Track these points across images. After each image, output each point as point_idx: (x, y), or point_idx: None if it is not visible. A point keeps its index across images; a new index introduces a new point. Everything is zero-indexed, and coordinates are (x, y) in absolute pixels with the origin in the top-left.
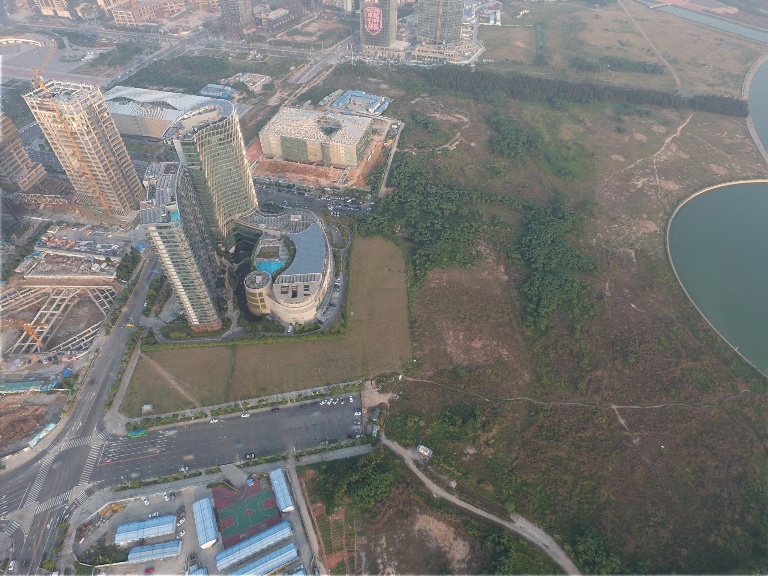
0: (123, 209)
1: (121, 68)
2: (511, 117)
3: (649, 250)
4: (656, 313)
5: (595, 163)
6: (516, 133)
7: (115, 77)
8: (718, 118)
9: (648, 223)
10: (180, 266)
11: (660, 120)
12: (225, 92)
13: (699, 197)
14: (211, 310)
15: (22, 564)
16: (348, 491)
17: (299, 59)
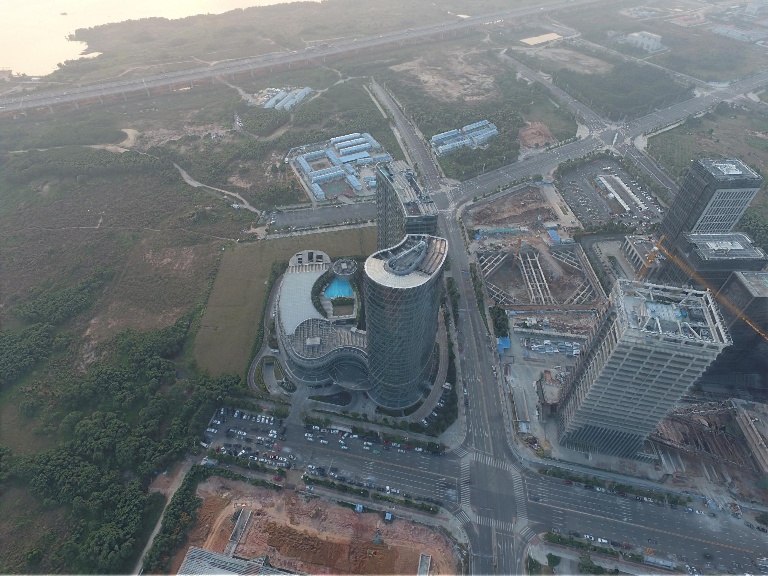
0: None
1: None
2: None
3: None
4: None
5: None
6: None
7: None
8: None
9: None
10: None
11: None
12: None
13: None
14: None
15: None
16: None
17: None
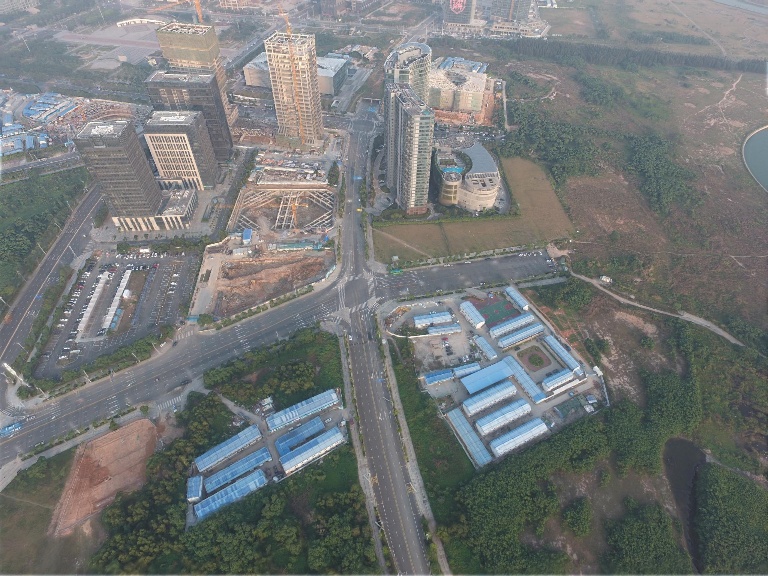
0: (314, 138)
1: (245, 42)
2: (592, 76)
3: (732, 165)
4: (748, 204)
5: (672, 108)
6: (602, 87)
7: (244, 49)
8: (764, 77)
9: (726, 148)
10: (422, 153)
11: (717, 78)
12: None
13: (761, 132)
14: (426, 194)
15: (357, 337)
16: (563, 299)
17: (394, 34)
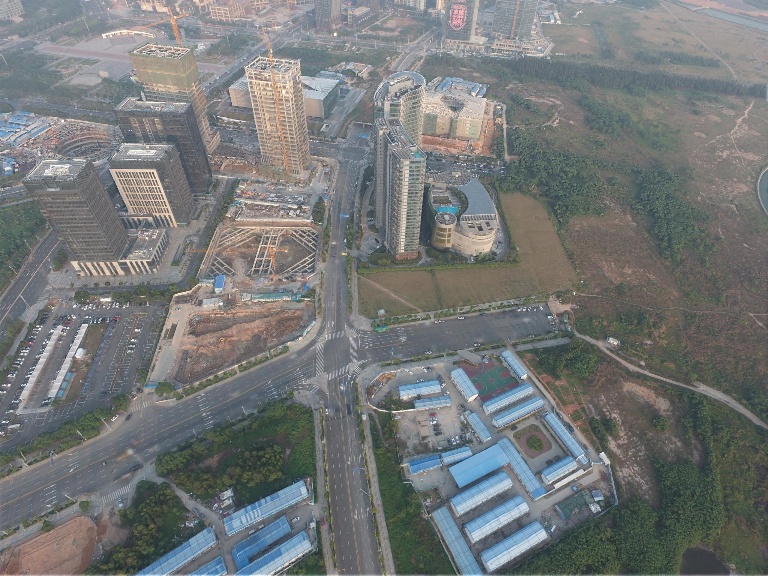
0: (299, 168)
1: None
2: (597, 101)
3: (747, 205)
4: (766, 250)
5: (682, 138)
6: (608, 113)
7: (233, 65)
8: None
9: (740, 185)
10: (412, 197)
11: (728, 105)
12: (337, 78)
13: None
14: (417, 239)
15: (334, 411)
16: (565, 366)
17: (390, 51)
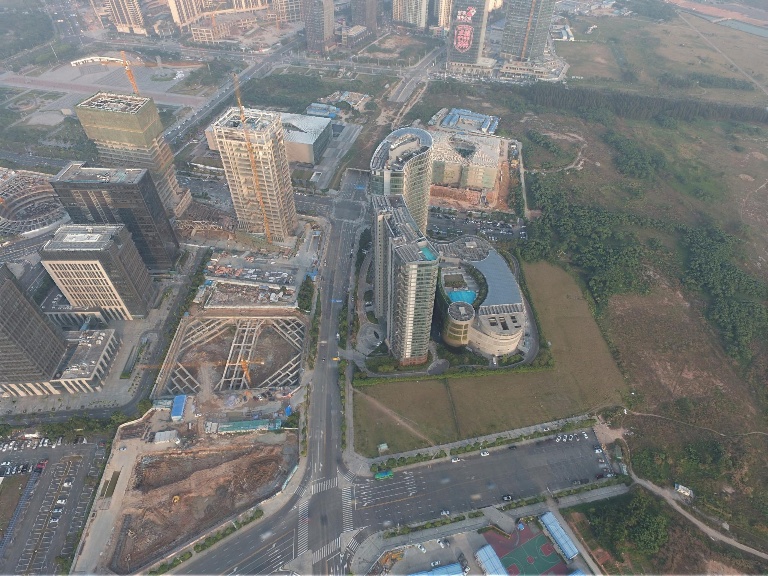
0: (283, 236)
1: None
2: (624, 136)
3: None
4: None
5: (726, 183)
6: (639, 153)
7: (214, 96)
8: None
9: None
10: (421, 302)
11: None
12: (330, 111)
13: None
14: (427, 344)
15: None
16: (626, 535)
17: (389, 77)
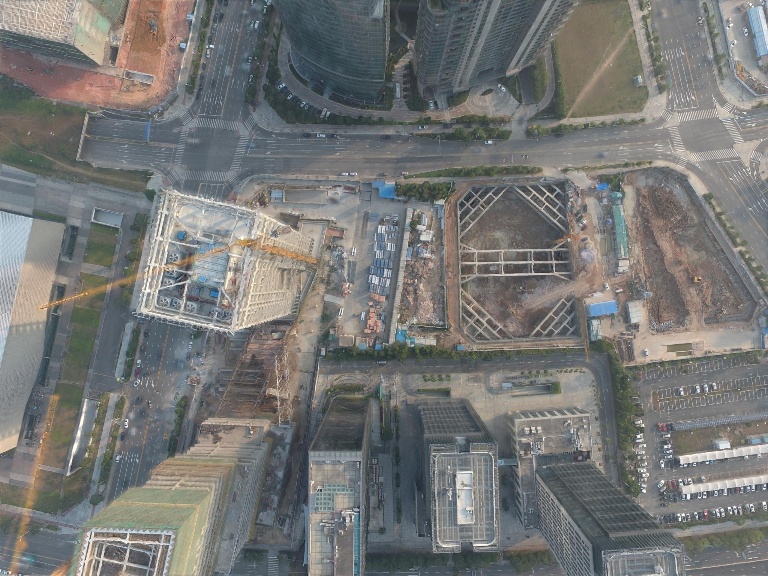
0: None
1: None
2: None
3: None
4: None
5: None
6: None
7: None
8: None
9: None
10: None
11: None
12: None
13: None
14: None
15: None
16: None
17: None
